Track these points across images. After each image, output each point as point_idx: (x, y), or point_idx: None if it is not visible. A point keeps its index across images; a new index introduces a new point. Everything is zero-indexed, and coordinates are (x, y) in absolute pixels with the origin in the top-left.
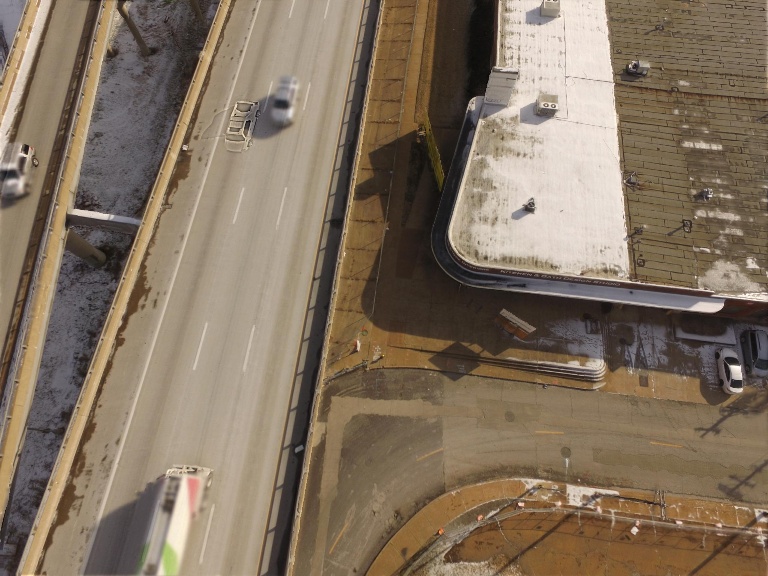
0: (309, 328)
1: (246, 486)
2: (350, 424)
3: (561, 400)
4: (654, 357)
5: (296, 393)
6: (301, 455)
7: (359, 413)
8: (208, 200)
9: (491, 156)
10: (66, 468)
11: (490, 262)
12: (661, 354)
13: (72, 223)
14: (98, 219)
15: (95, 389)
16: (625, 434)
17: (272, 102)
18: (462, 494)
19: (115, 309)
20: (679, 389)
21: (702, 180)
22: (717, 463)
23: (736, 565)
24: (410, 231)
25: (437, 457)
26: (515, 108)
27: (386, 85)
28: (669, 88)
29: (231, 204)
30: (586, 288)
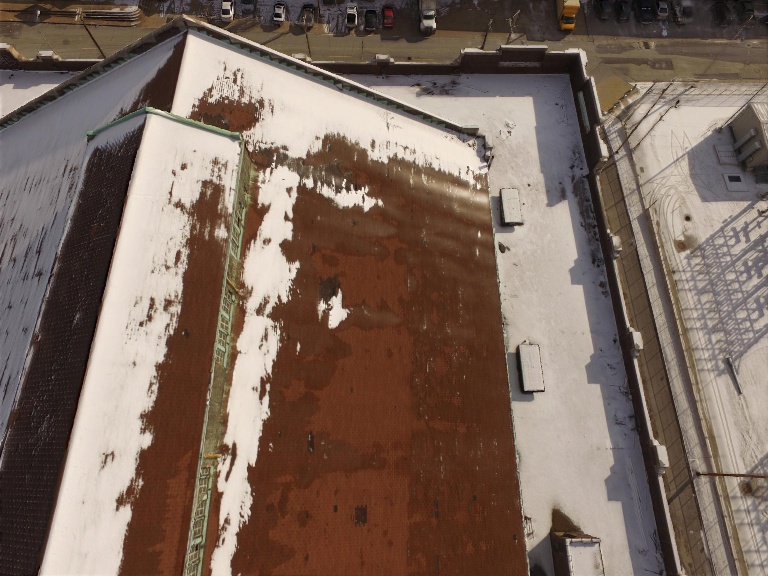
0: None
1: None
2: None
3: (106, 33)
4: (180, 7)
5: None
6: None
7: None
8: None
9: None
10: None
11: None
12: (186, 5)
13: None
14: None
15: None
16: None
17: None
18: None
19: None
20: None
21: None
22: None
23: None
24: None
25: None
26: None
27: None
28: None
29: None
30: None
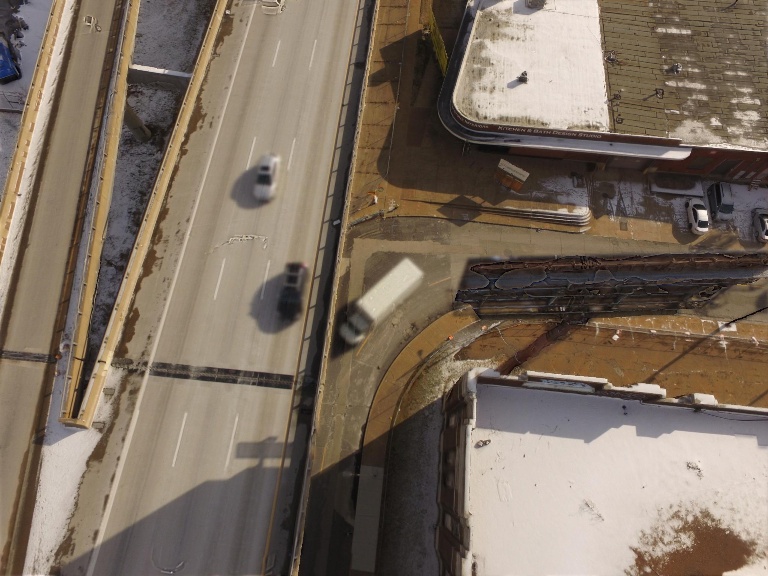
0: (340, 140)
1: (295, 248)
2: (371, 259)
3: (552, 241)
4: (632, 207)
5: (332, 185)
6: (338, 226)
7: (378, 251)
8: (250, 50)
9: (488, 40)
10: (147, 237)
11: (489, 121)
12: (639, 205)
13: (131, 80)
14: (155, 72)
15: (166, 184)
16: None
17: None
18: (468, 311)
19: (179, 126)
20: (654, 232)
21: (673, 58)
22: None
23: (701, 362)
24: (418, 109)
25: (446, 284)
26: (509, 2)
27: None
28: None
29: (270, 52)
30: (572, 142)
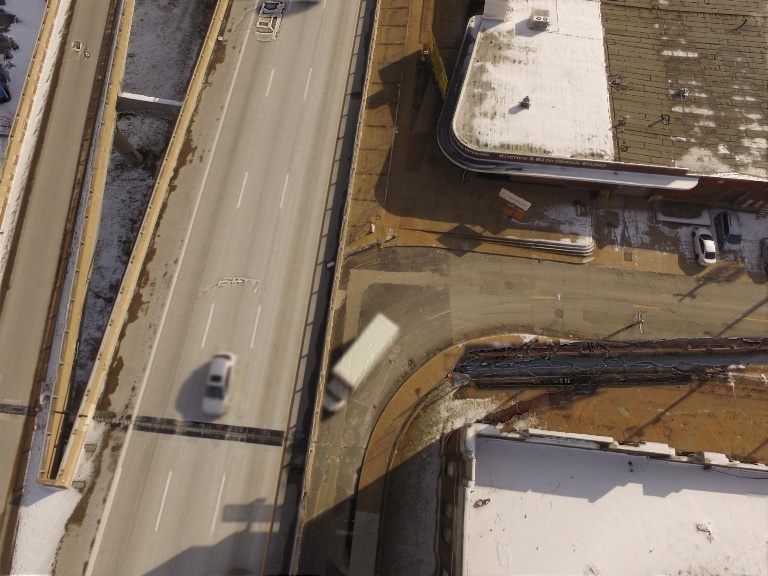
0: (335, 175)
1: (287, 292)
2: (367, 291)
3: (554, 272)
4: (637, 237)
5: (326, 224)
6: (332, 269)
7: (375, 282)
8: (243, 79)
9: (490, 63)
10: (133, 280)
11: (490, 148)
12: (644, 234)
13: (120, 108)
14: (145, 101)
15: (154, 223)
16: (611, 299)
17: (296, 1)
18: (468, 346)
19: (168, 160)
20: (660, 263)
21: (679, 82)
22: (693, 322)
23: (709, 401)
24: (417, 134)
25: (445, 317)
26: (511, 23)
27: (392, 13)
28: (650, 6)
29: (263, 82)
30: (576, 170)
